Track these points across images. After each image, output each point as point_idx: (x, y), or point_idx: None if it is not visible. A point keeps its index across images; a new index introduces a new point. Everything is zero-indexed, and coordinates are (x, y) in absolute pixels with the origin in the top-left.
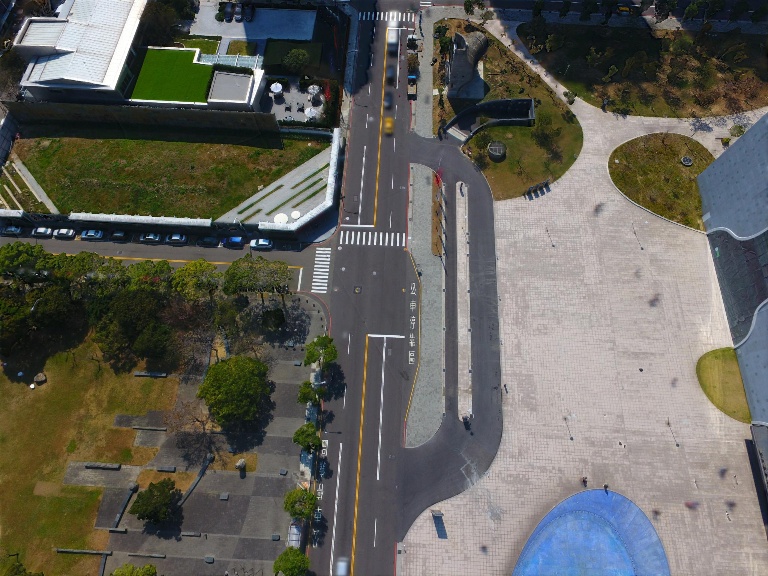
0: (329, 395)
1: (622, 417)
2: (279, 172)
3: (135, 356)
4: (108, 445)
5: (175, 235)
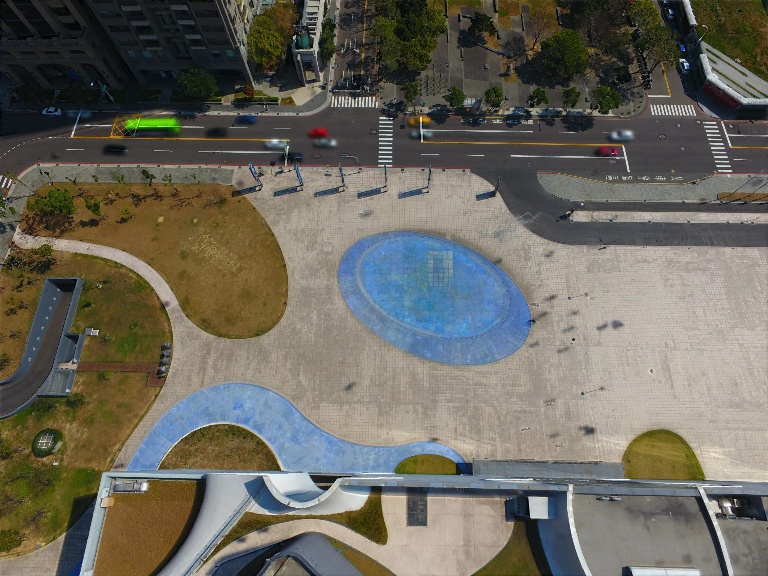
0: (567, 122)
1: (599, 345)
2: (760, 72)
3: (570, 7)
4: (509, 4)
5: (672, 11)
